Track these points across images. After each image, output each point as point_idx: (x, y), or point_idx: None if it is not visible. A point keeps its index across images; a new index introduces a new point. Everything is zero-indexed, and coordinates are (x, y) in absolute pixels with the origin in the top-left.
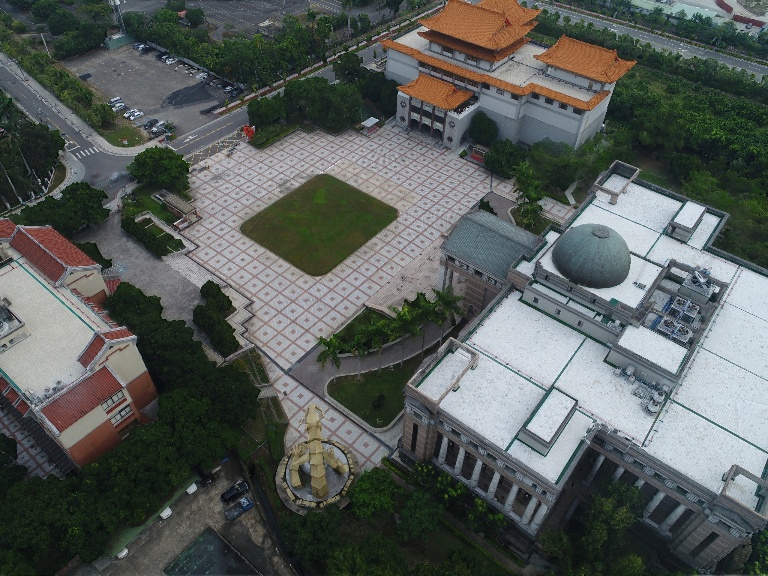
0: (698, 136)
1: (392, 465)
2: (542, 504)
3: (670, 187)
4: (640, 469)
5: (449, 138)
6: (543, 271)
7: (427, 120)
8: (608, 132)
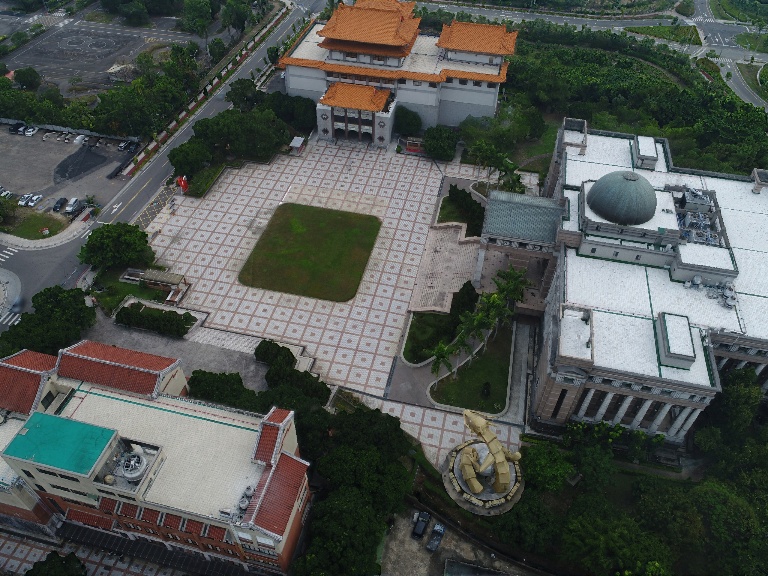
0: (573, 85)
1: (532, 439)
2: (696, 410)
3: None
4: (744, 353)
5: (380, 138)
6: (594, 223)
7: (353, 126)
8: (501, 99)
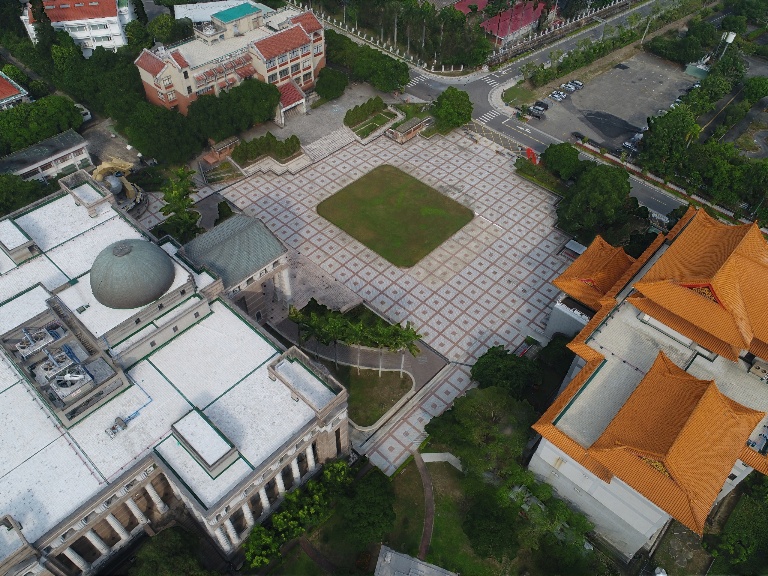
0: None
1: None
2: None
3: None
4: None
5: None
6: None
7: None
8: None
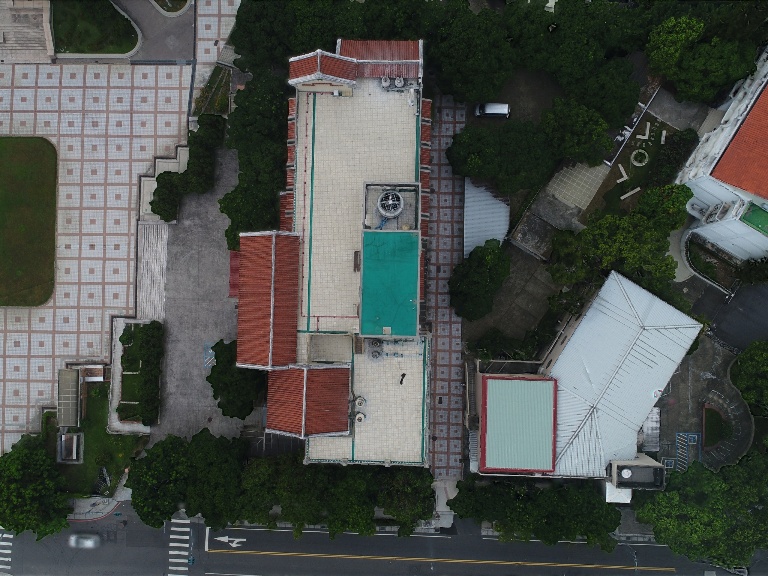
0: None
1: None
2: None
3: None
4: None
5: None
6: None
7: None
8: None
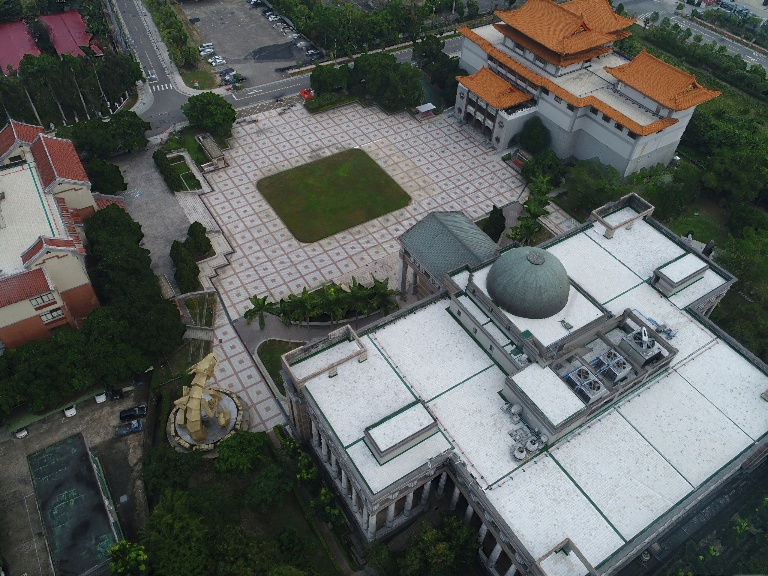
0: None
1: (281, 434)
2: None
3: (724, 240)
4: (482, 511)
5: (497, 138)
6: (471, 284)
7: (480, 116)
8: None
